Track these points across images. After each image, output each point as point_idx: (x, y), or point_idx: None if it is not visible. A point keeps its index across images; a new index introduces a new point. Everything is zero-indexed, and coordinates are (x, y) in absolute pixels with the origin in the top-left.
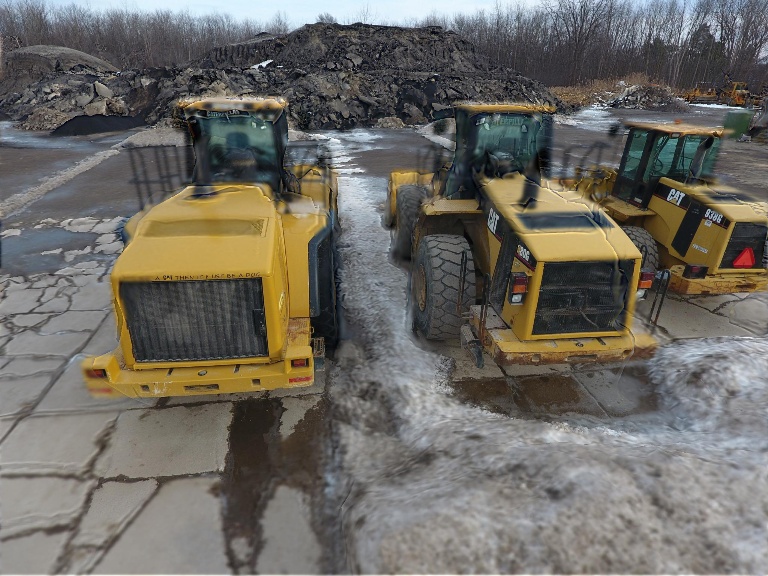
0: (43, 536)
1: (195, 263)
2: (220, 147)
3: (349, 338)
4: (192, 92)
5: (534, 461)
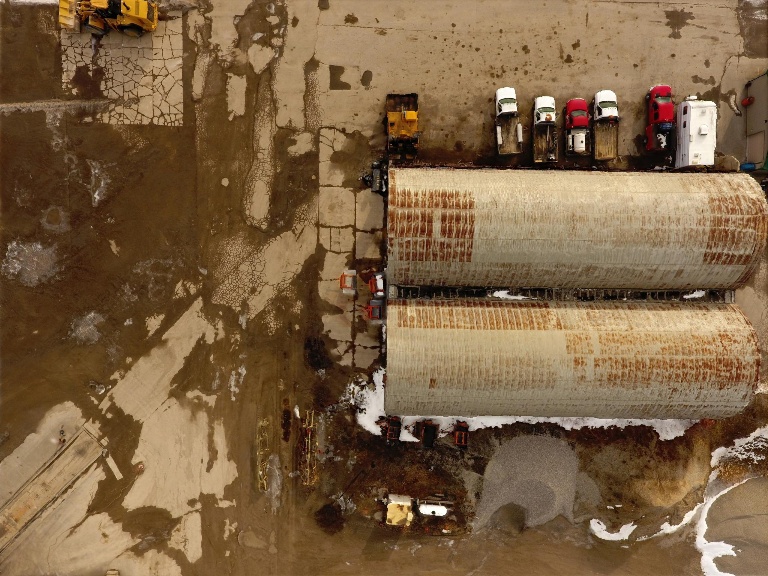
0: (172, 37)
1: (145, 8)
2: (113, 3)
3: None
4: None
5: None
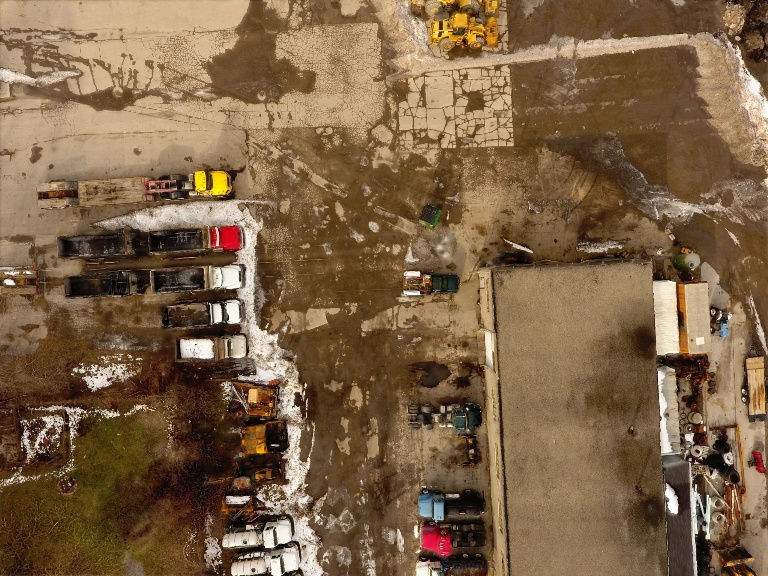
0: None
1: None
2: None
3: None
4: None
5: None
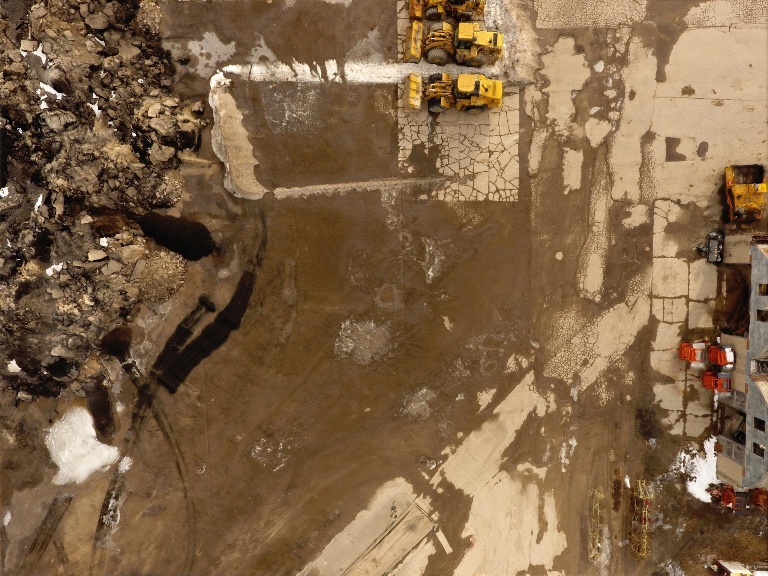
0: (508, 113)
1: None
2: None
3: None
4: (118, 175)
5: None
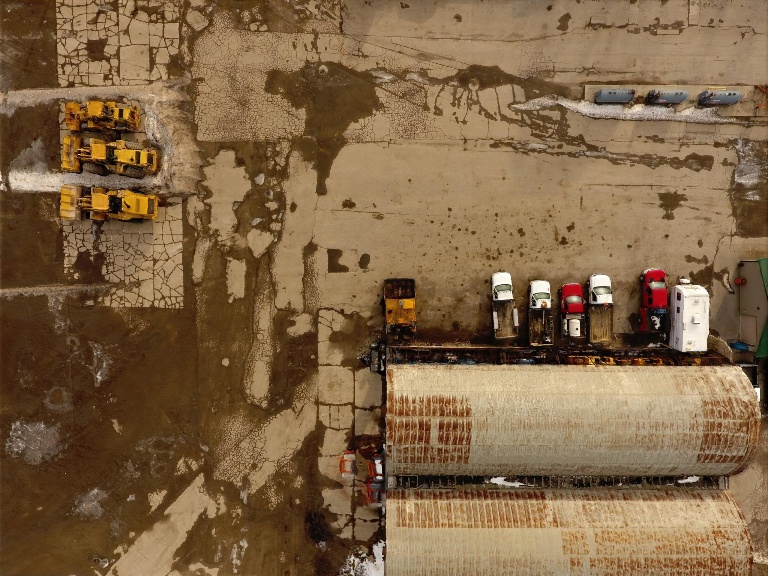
0: (172, 223)
1: None
2: None
3: (138, 189)
4: None
5: (171, 173)
